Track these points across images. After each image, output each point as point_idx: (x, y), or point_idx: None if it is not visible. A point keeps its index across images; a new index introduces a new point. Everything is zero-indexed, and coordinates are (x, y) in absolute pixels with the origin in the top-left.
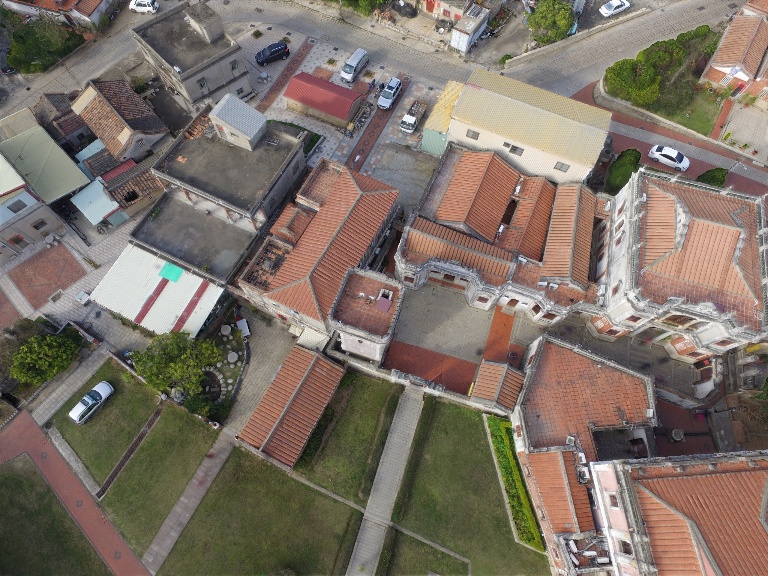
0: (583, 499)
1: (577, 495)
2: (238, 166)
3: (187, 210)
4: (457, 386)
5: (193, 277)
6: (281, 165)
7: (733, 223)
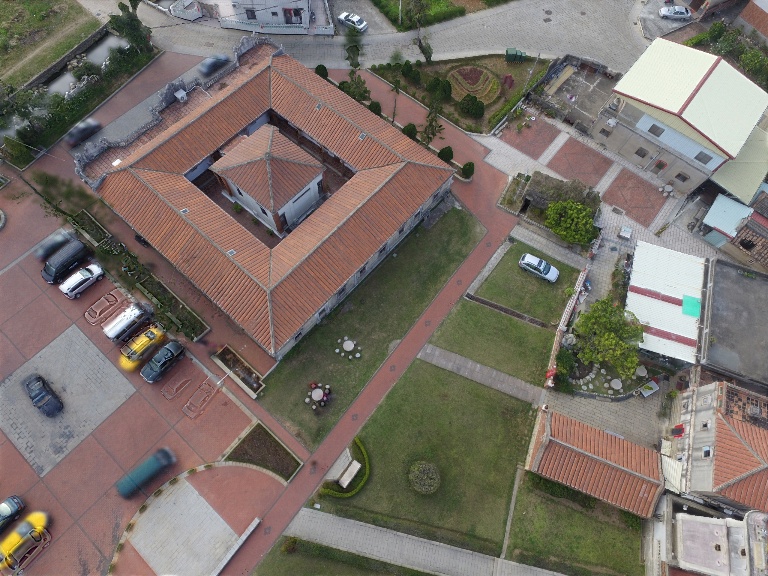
0: None
1: None
2: None
3: (765, 304)
4: None
5: (695, 329)
6: None
7: None
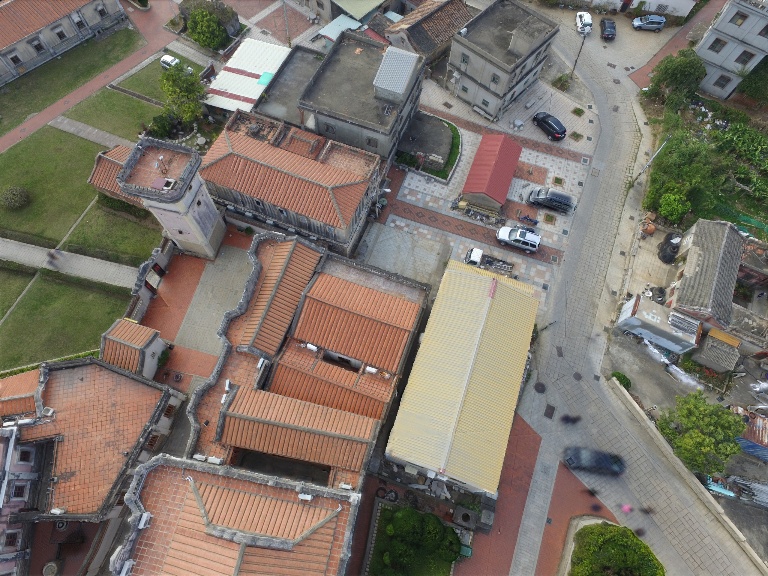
0: None
1: None
2: (355, 89)
3: None
4: (153, 321)
5: None
6: (356, 118)
7: None
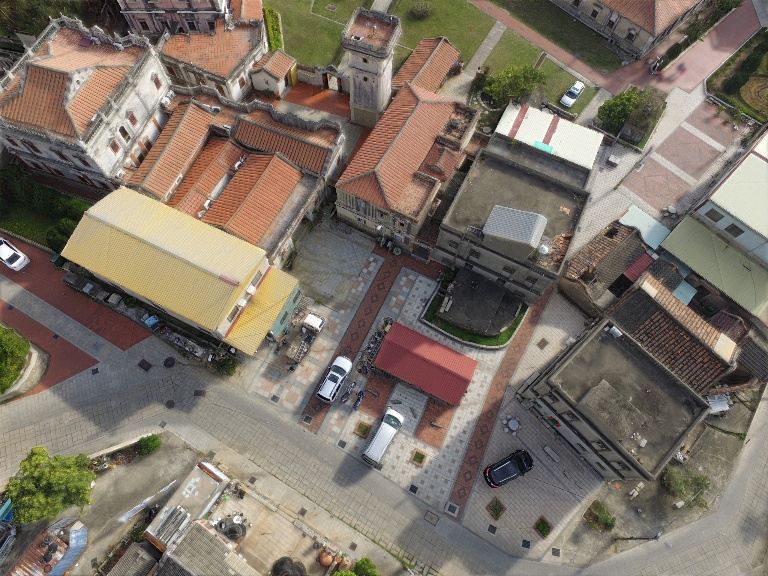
0: (234, 3)
1: (238, 3)
2: (504, 202)
3: None
4: (302, 88)
5: None
6: None
7: (30, 74)
